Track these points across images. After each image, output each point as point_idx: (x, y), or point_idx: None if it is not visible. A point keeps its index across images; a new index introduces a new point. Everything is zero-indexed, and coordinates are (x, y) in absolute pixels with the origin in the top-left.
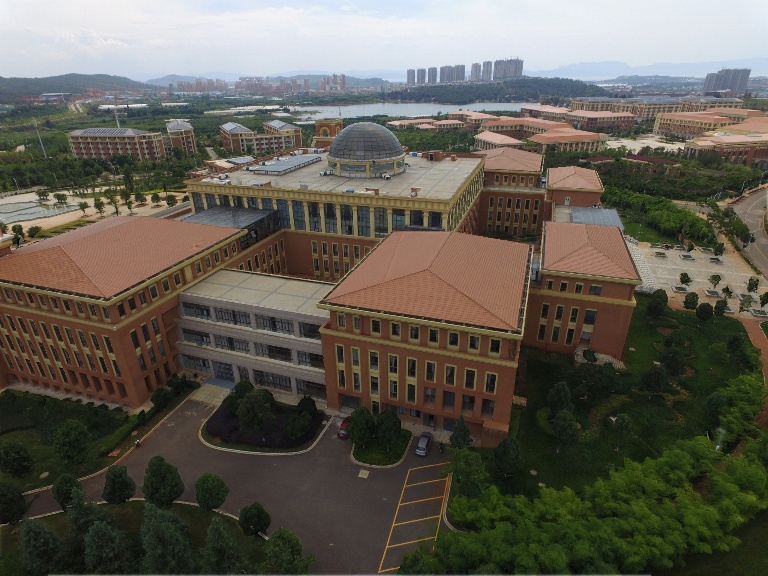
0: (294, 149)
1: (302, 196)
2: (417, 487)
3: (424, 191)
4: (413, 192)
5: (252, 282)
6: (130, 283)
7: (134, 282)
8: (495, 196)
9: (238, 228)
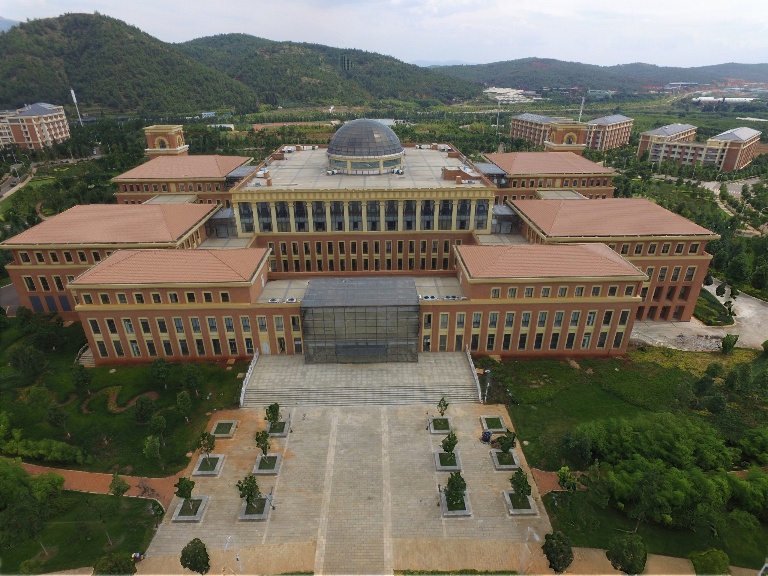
0: (439, 144)
1: None
2: None
3: (285, 186)
4: (266, 182)
5: None
6: (131, 177)
7: (133, 177)
8: None
9: (226, 176)
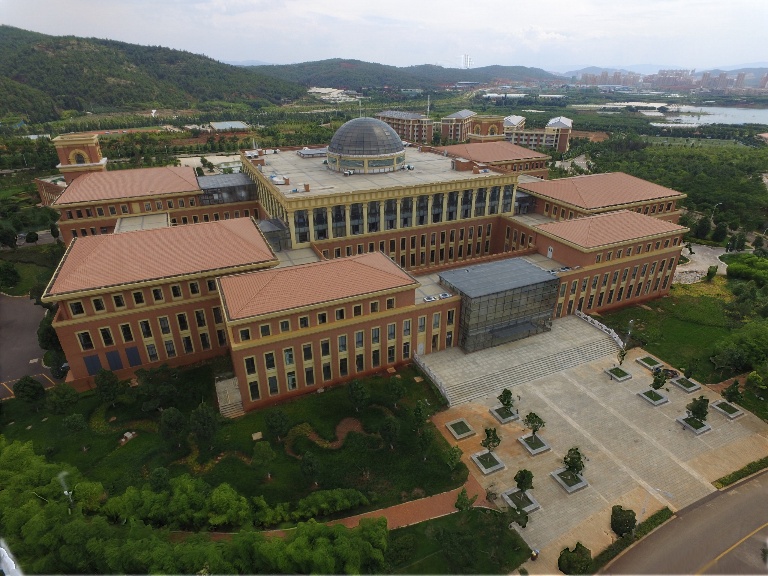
0: None
1: (258, 174)
2: None
3: (325, 190)
4: (303, 188)
5: (153, 225)
6: (78, 200)
7: (81, 200)
8: (511, 226)
9: (201, 188)
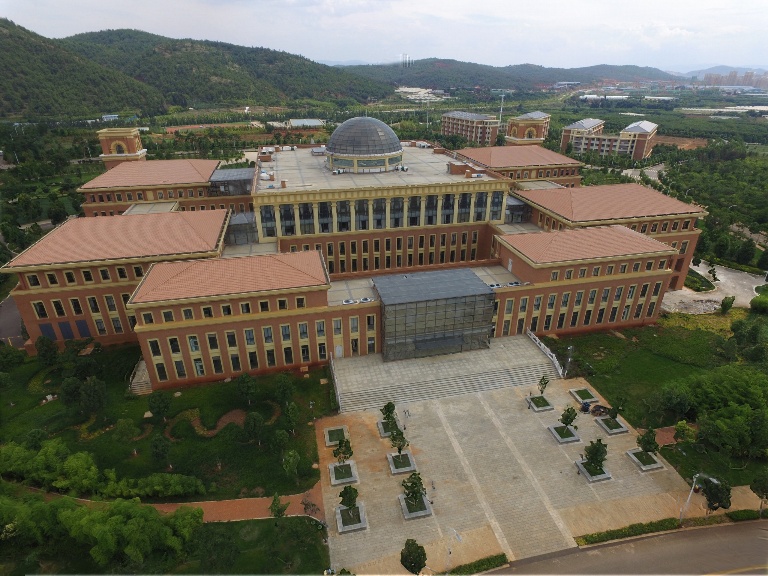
0: None
1: None
2: (6, 341)
3: (301, 187)
4: None
5: None
6: (100, 186)
7: (102, 186)
8: None
9: (209, 180)
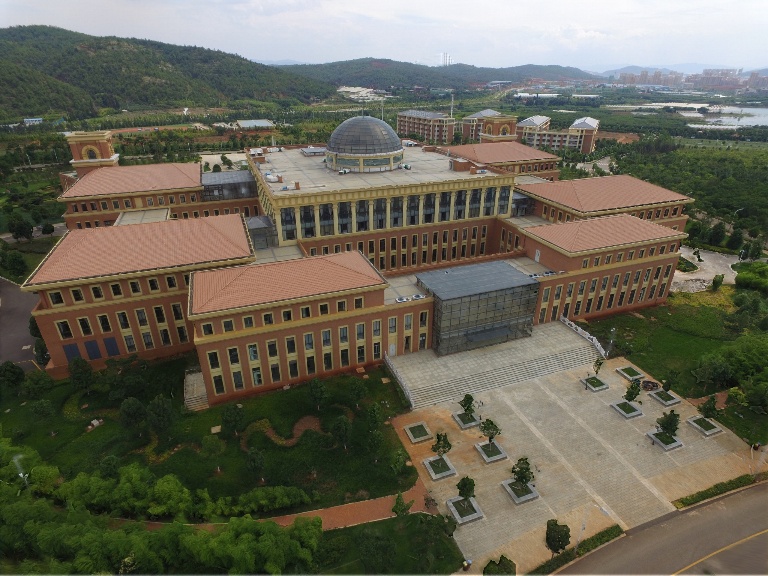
0: None
1: None
2: None
3: (315, 188)
4: None
5: (152, 219)
6: (83, 194)
7: (86, 194)
8: (506, 228)
9: None
